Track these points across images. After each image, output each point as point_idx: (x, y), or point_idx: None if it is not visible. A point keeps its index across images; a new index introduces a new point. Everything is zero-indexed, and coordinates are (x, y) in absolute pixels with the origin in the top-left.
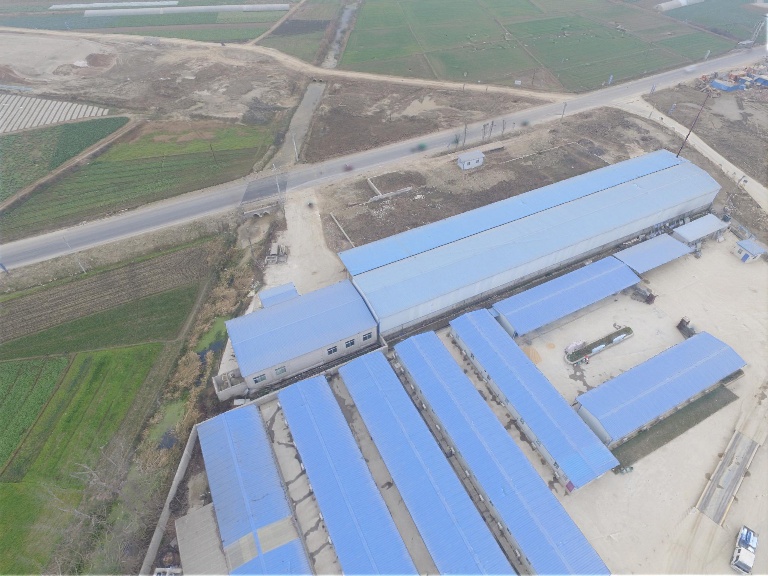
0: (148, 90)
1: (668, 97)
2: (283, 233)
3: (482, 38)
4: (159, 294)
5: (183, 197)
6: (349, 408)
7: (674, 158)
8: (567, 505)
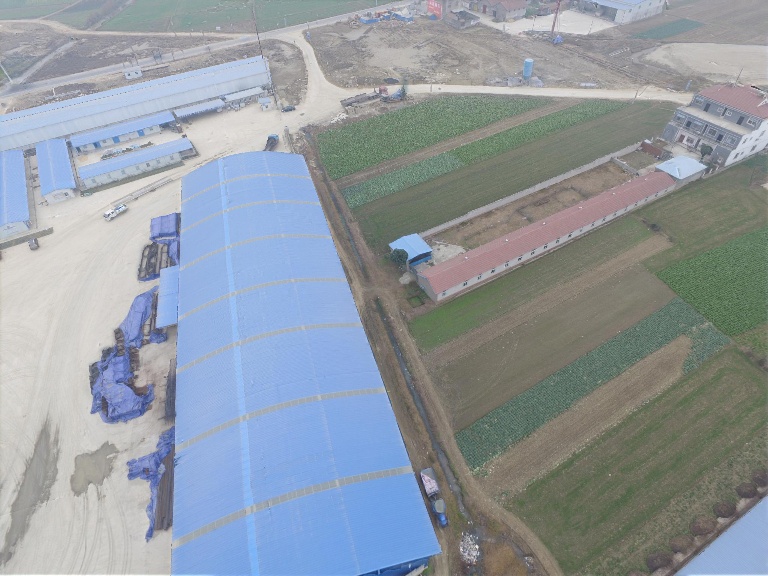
0: None
1: (319, 30)
2: None
3: (228, 3)
4: None
5: None
6: None
7: (244, 56)
8: None
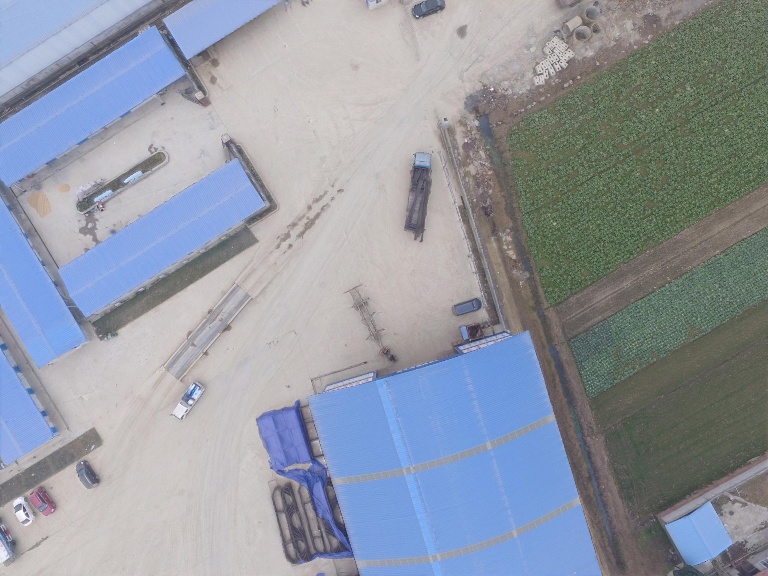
0: None
1: None
2: None
3: None
4: None
5: None
6: None
7: None
8: (49, 374)
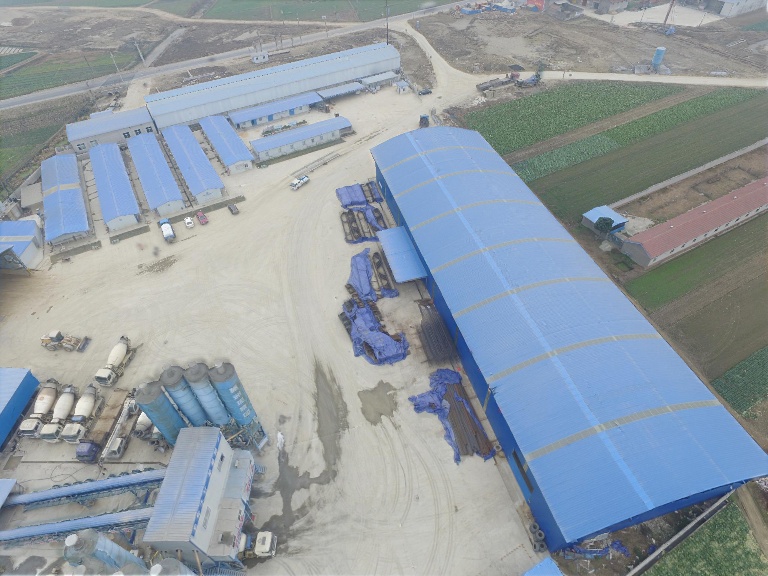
0: (55, 37)
1: None
2: (123, 98)
3: None
4: (38, 128)
5: (63, 86)
6: (130, 158)
7: (375, 41)
8: (226, 178)
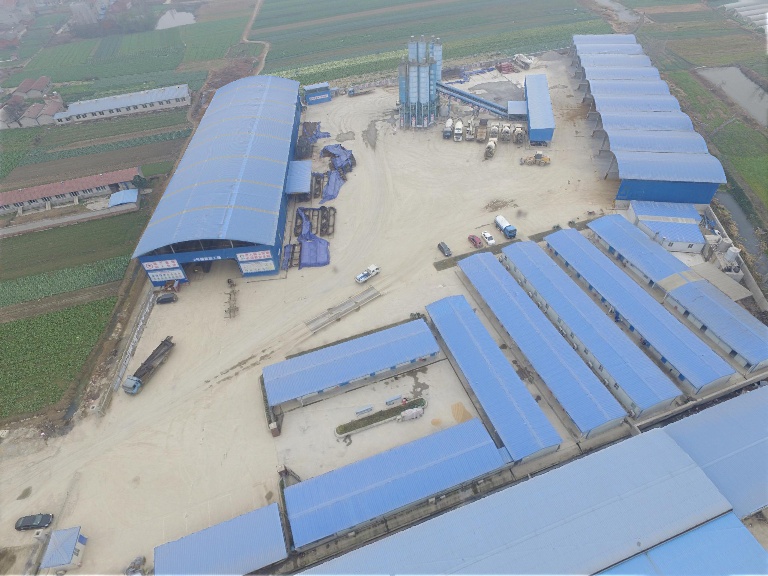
0: None
1: None
2: None
3: None
4: None
5: None
6: None
7: None
8: None
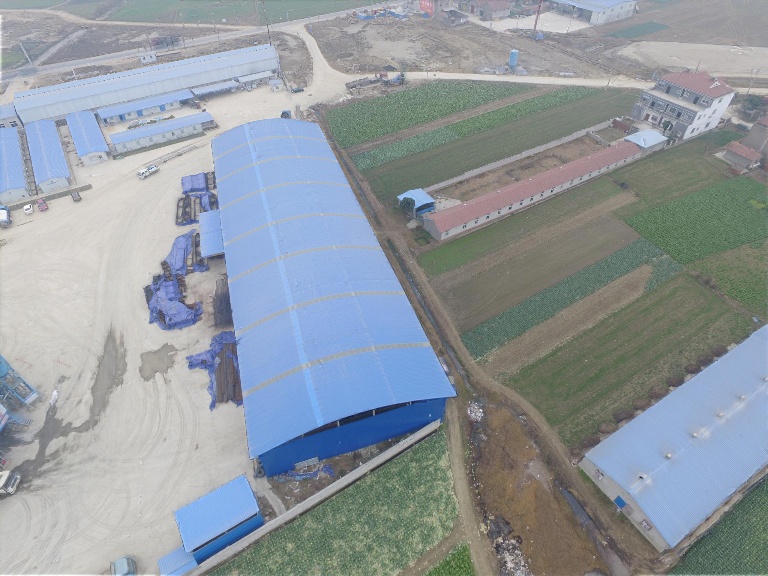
0: None
1: None
2: None
3: None
4: None
5: None
6: None
7: None
8: (79, 169)
